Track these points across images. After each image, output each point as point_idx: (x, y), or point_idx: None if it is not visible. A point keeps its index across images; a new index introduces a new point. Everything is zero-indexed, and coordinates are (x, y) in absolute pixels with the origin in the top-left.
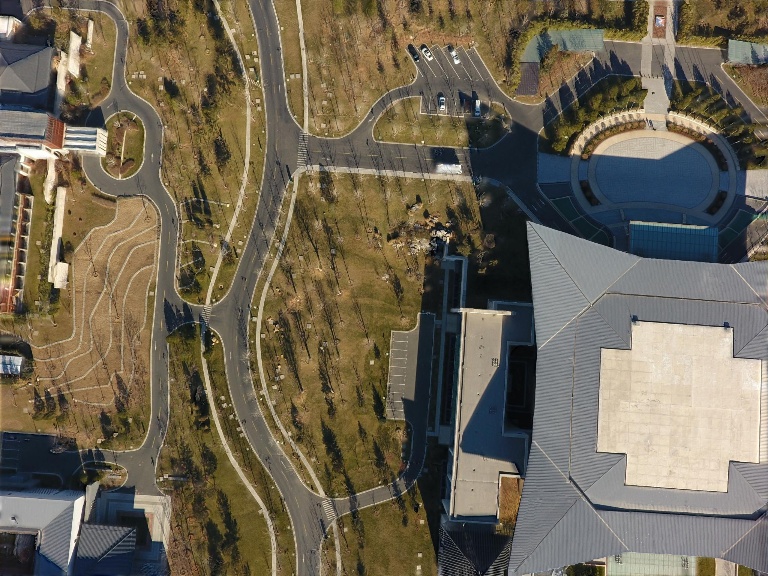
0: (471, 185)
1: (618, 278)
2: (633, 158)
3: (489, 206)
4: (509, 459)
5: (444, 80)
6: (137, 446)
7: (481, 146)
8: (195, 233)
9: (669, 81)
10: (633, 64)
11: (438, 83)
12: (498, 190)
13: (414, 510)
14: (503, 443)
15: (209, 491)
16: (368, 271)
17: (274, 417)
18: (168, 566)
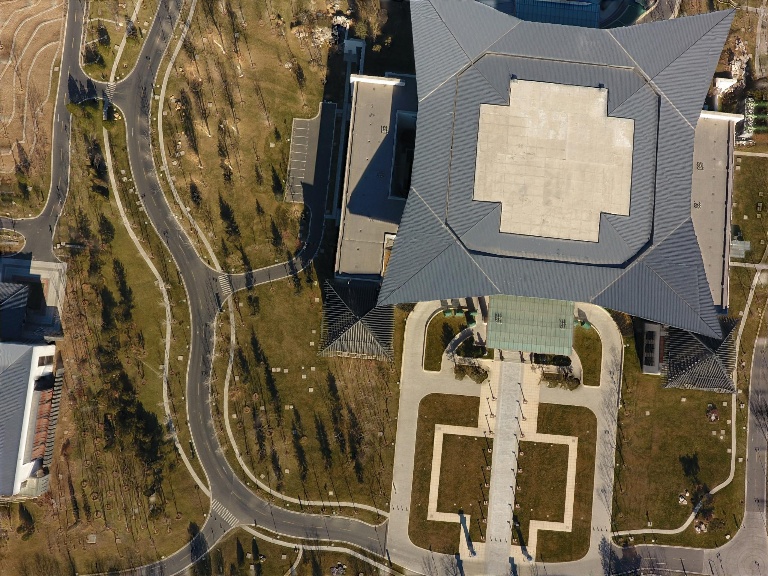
0: None
1: (498, 38)
2: None
3: None
4: (395, 221)
5: None
6: (36, 214)
7: None
8: (101, 11)
9: None
10: None
11: None
12: None
13: (306, 281)
14: (389, 206)
15: (102, 251)
16: (271, 57)
17: (173, 192)
18: (61, 330)
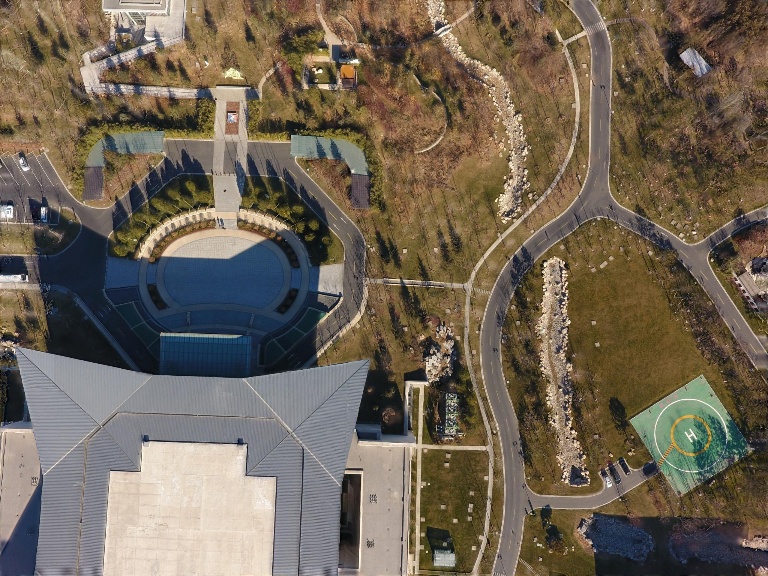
0: (39, 293)
1: (128, 397)
2: (202, 259)
3: (55, 314)
4: None
5: (14, 187)
6: None
7: (49, 253)
8: None
9: (241, 178)
10: (204, 162)
11: (8, 191)
12: (65, 297)
13: None
14: None
15: None
16: None
17: None
18: None
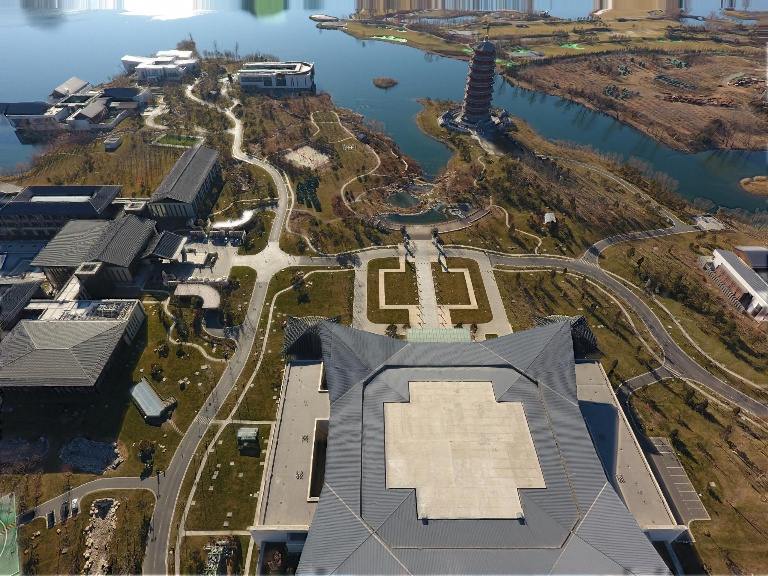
0: None
1: (555, 567)
2: None
3: None
4: None
5: None
6: None
7: None
8: None
9: None
10: None
11: None
12: None
13: None
14: (582, 413)
15: None
16: None
17: (766, 430)
18: (763, 331)
